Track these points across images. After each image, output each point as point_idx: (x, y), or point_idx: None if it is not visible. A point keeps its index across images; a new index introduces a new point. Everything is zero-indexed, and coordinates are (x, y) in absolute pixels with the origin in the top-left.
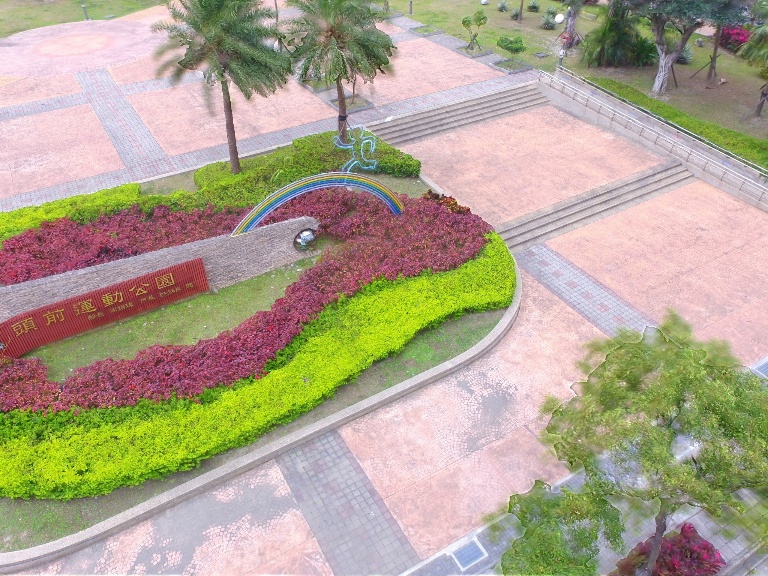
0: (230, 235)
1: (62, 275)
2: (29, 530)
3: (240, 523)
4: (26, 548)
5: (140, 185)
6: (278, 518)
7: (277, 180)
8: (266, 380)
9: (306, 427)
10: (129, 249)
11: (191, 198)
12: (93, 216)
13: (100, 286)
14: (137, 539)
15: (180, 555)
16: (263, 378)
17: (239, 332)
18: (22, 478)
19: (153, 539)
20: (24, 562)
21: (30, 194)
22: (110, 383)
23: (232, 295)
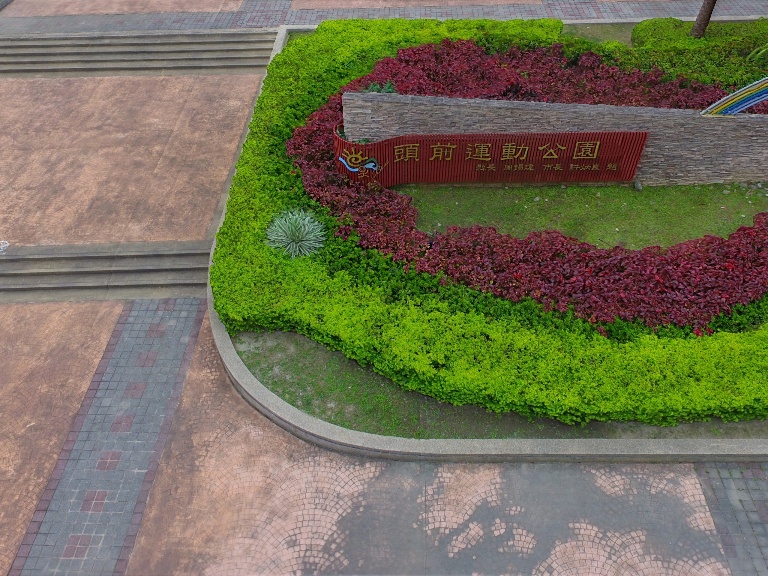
0: (700, 112)
1: (471, 100)
2: (357, 406)
3: (627, 539)
4: (349, 427)
5: (562, 24)
6: (690, 563)
7: (760, 59)
8: (712, 342)
9: (758, 439)
10: (544, 96)
11: (630, 54)
12: (502, 46)
13: (507, 130)
14: (478, 484)
15: (533, 540)
16: (706, 337)
17: (678, 255)
18: (367, 339)
19: (499, 495)
20: (343, 444)
21: (431, 9)
22: (489, 259)
23: (660, 199)
